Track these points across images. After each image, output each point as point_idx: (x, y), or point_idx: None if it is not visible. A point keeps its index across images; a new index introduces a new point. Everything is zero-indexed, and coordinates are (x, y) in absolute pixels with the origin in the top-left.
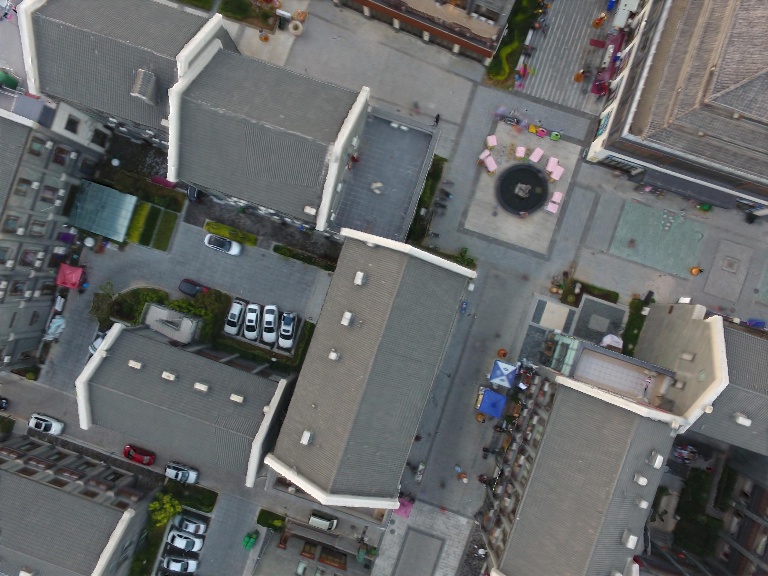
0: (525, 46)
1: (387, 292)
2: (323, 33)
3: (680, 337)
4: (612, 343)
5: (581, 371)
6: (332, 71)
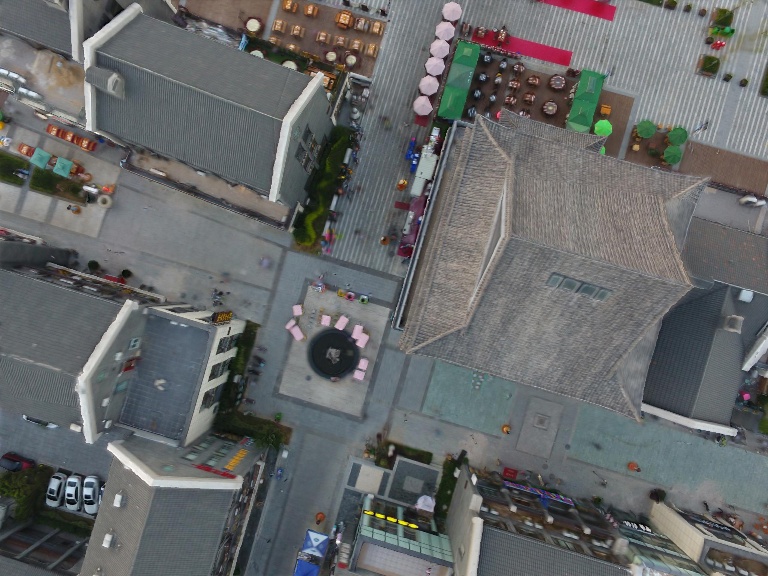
0: (330, 212)
1: (140, 519)
2: (134, 204)
3: (462, 523)
4: (423, 507)
5: (367, 560)
6: (144, 241)
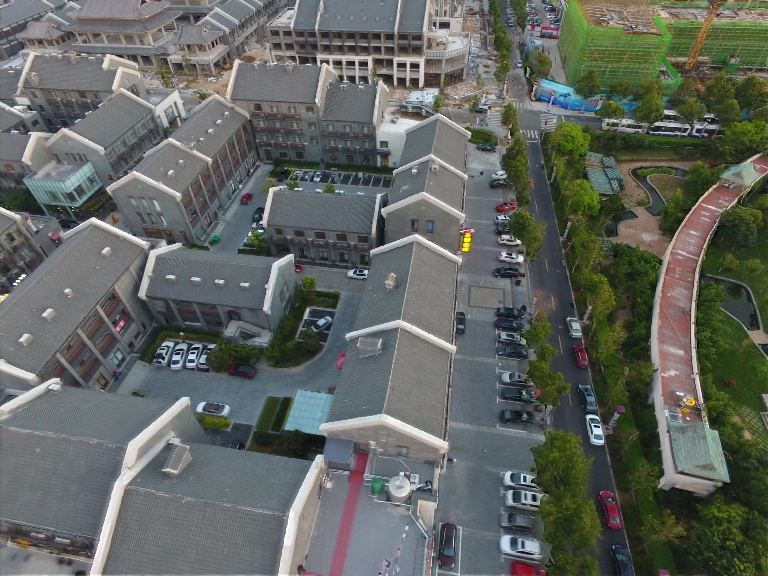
0: None
1: None
2: None
3: None
4: None
5: None
6: None
